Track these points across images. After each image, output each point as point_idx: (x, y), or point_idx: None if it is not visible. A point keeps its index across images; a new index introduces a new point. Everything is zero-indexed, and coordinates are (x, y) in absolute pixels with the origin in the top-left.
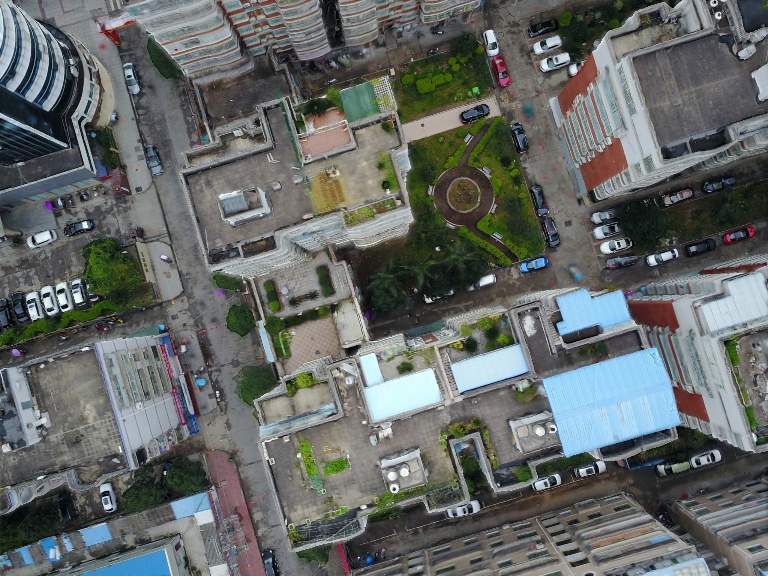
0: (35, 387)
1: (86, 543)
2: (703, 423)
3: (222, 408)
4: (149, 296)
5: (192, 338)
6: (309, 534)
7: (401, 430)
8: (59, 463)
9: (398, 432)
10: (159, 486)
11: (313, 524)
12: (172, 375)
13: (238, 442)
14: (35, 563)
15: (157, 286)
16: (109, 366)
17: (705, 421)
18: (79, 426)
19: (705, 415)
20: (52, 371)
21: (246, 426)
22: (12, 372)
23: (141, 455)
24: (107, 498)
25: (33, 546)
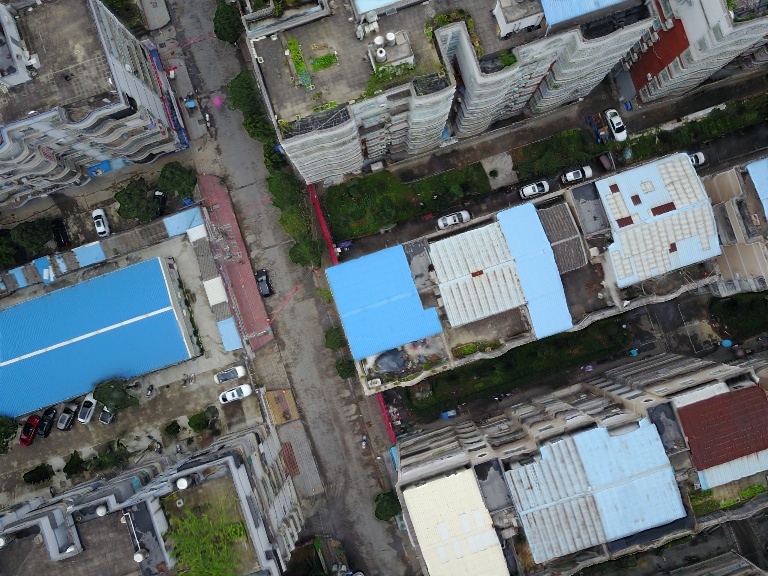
0: (24, 30)
1: (80, 263)
2: (683, 55)
3: (212, 134)
4: (136, 19)
5: (180, 66)
6: (299, 126)
7: (387, 25)
8: (50, 103)
9: (384, 27)
10: (151, 200)
11: (303, 120)
12: (161, 86)
13: (229, 167)
14: (29, 293)
15: (144, 15)
16: (97, 8)
17: (685, 49)
18: (69, 66)
19: (685, 42)
20: (40, 14)
21: (236, 150)
22: (0, 5)
23: (131, 101)
24: (99, 220)
25: (27, 267)
